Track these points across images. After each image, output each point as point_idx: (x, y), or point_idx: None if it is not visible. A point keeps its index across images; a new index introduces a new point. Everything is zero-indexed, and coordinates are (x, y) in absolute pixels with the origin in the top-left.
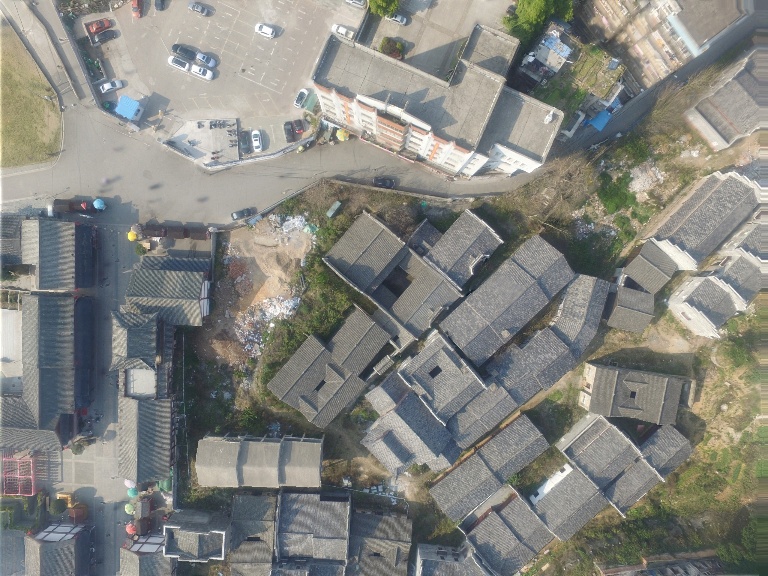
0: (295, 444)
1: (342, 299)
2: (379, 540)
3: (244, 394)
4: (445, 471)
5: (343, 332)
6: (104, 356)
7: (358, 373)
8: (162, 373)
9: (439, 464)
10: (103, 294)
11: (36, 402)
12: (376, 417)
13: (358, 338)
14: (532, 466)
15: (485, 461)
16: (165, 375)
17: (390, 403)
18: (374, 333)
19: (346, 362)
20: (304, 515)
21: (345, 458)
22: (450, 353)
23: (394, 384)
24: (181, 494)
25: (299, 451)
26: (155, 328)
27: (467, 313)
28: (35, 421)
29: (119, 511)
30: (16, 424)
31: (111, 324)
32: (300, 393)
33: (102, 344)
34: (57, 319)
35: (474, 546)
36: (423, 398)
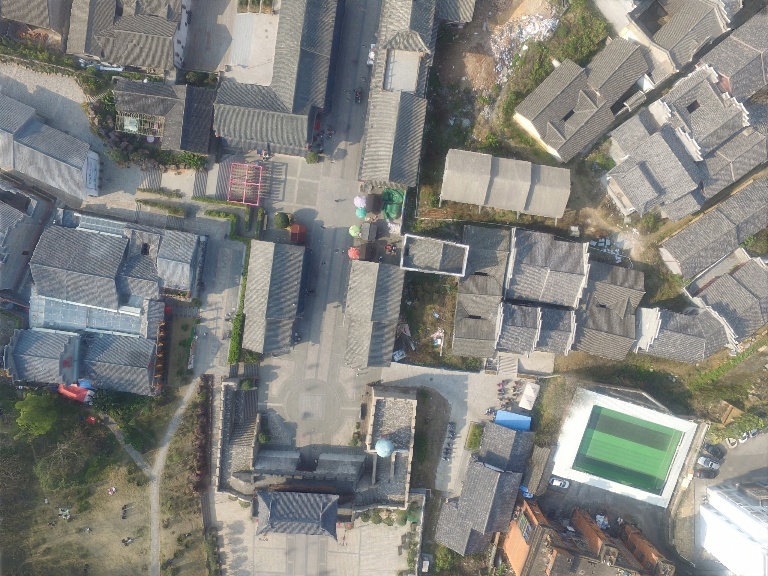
0: (543, 167)
1: (599, 27)
2: (611, 287)
3: (484, 122)
4: (671, 235)
5: (601, 58)
6: (344, 68)
7: (611, 104)
8: (422, 70)
9: (683, 210)
10: (351, 2)
11: (290, 87)
12: (611, 166)
13: (619, 62)
14: (765, 233)
15: (725, 216)
16: (425, 73)
17: (642, 137)
18: (635, 59)
19: (604, 86)
20: (539, 251)
21: (574, 208)
22: (712, 86)
23: (646, 119)
24: (407, 223)
25: (548, 174)
26: (434, 7)
27: (733, 47)
28: (286, 107)
29: (338, 238)
30: (266, 108)
31: (355, 35)
32: (550, 118)
33: (343, 55)
34: (321, 1)
35: (706, 304)
36: (681, 130)
